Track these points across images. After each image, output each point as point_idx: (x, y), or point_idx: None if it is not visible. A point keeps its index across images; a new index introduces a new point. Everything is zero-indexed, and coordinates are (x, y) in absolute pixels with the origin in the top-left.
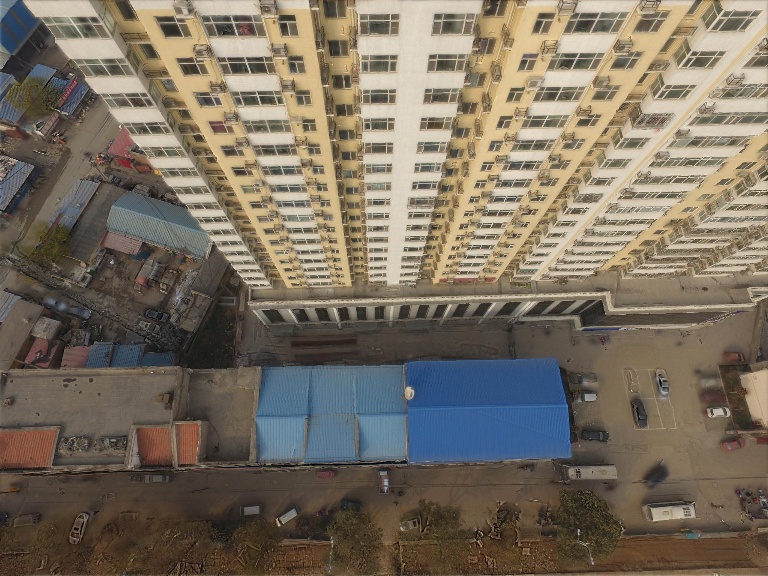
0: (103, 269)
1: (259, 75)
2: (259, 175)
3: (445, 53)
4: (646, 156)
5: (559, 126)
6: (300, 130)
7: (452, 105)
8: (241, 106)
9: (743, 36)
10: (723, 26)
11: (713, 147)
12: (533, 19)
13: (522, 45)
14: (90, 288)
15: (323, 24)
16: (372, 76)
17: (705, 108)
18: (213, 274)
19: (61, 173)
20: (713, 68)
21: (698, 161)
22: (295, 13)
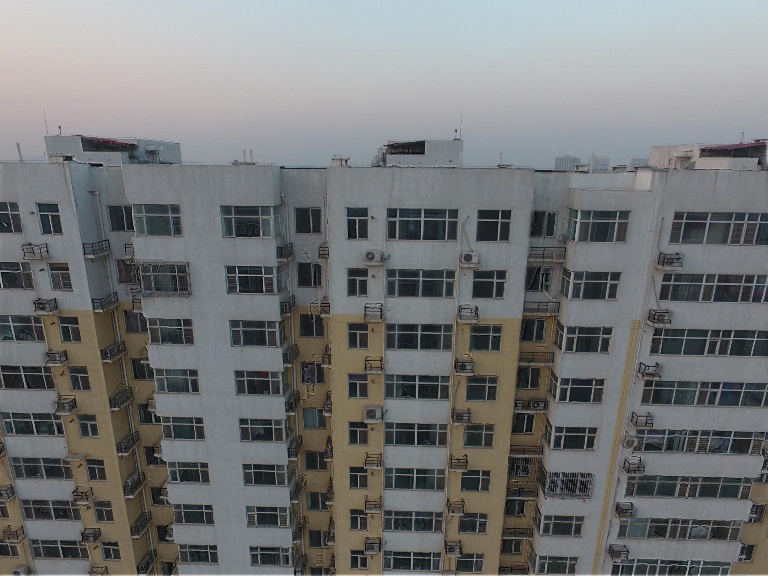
0: None
1: (35, 390)
2: (26, 556)
3: (252, 369)
4: (595, 552)
5: (438, 488)
6: (84, 476)
7: (279, 445)
8: (11, 435)
9: (610, 359)
10: (577, 346)
11: (691, 540)
12: (343, 330)
13: (342, 362)
14: None
15: (124, 339)
16: (170, 397)
17: (628, 464)
18: None
19: None
20: (602, 403)
21: (686, 568)
22: (78, 315)
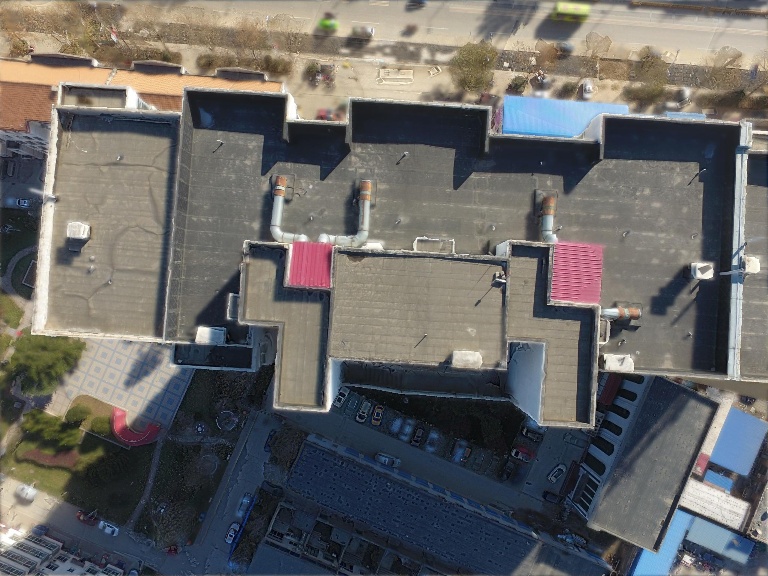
0: None
1: None
2: None
3: None
4: None
5: None
6: None
7: None
8: None
9: None
10: None
11: None
12: None
13: None
14: None
15: None
16: None
17: None
18: None
19: None
20: None
21: None
22: None
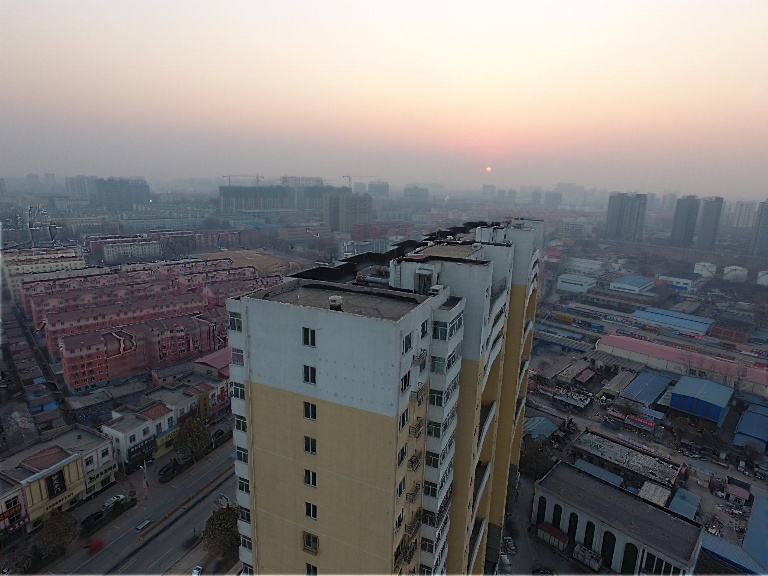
0: None
1: None
2: None
3: None
4: None
5: None
6: None
7: None
8: None
9: None
10: None
11: None
12: None
13: None
14: None
15: None
16: None
17: None
18: None
19: (581, 418)
20: None
21: None
22: None
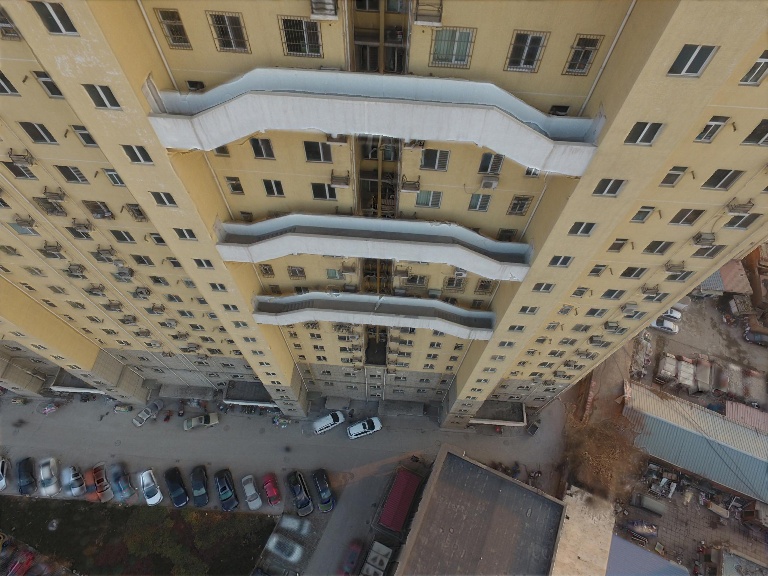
0: (762, 397)
1: None
2: None
3: None
4: None
5: None
6: None
7: None
8: None
9: None
10: None
11: None
12: None
13: None
14: (765, 373)
15: None
16: None
17: None
18: (611, 357)
19: None
20: None
21: None
22: None
